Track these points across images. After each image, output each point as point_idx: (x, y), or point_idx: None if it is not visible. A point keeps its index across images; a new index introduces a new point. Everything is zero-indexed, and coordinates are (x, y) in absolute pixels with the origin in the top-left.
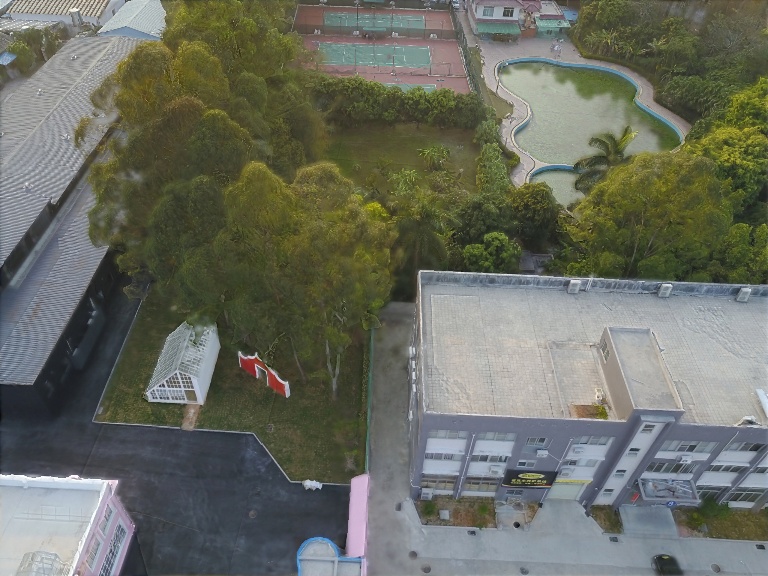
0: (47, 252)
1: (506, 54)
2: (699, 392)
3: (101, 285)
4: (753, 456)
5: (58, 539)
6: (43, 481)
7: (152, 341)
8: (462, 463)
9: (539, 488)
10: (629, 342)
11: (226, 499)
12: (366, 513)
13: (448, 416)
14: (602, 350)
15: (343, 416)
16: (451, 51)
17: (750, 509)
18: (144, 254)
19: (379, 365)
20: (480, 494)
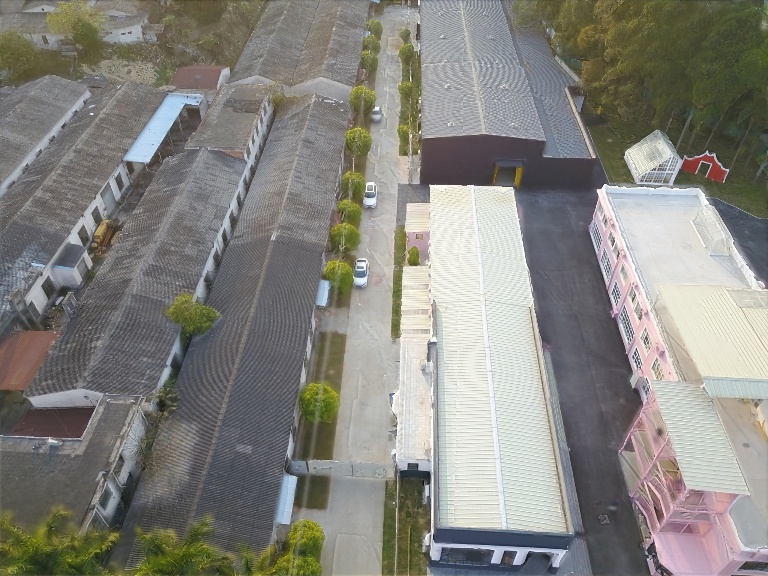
0: None
1: None
2: None
3: None
4: None
5: (692, 212)
6: (662, 189)
7: (611, 156)
8: None
9: None
10: None
11: None
12: None
13: None
14: None
15: (767, 191)
16: None
17: None
18: None
19: None
20: None
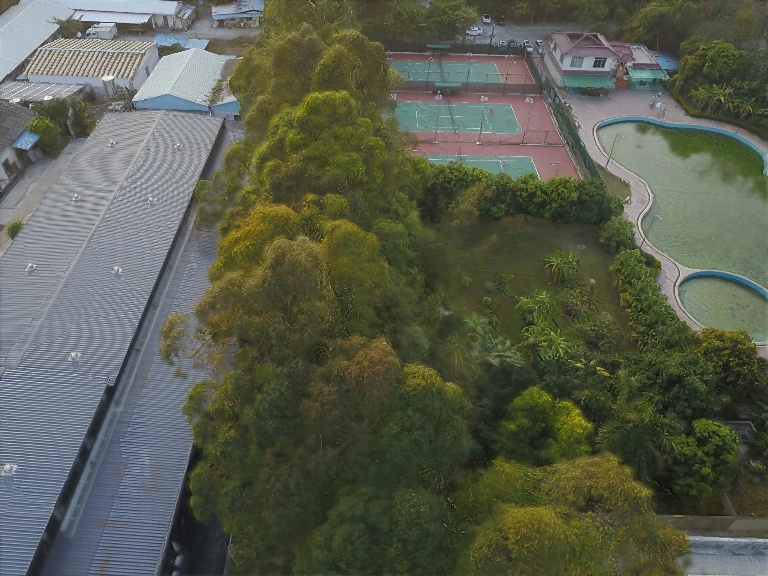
0: (107, 463)
1: (601, 113)
2: None
3: (182, 509)
4: None
5: None
6: None
7: None
8: None
9: None
10: None
11: None
12: None
13: None
14: None
15: None
16: (538, 110)
17: None
18: (277, 541)
19: None
20: None
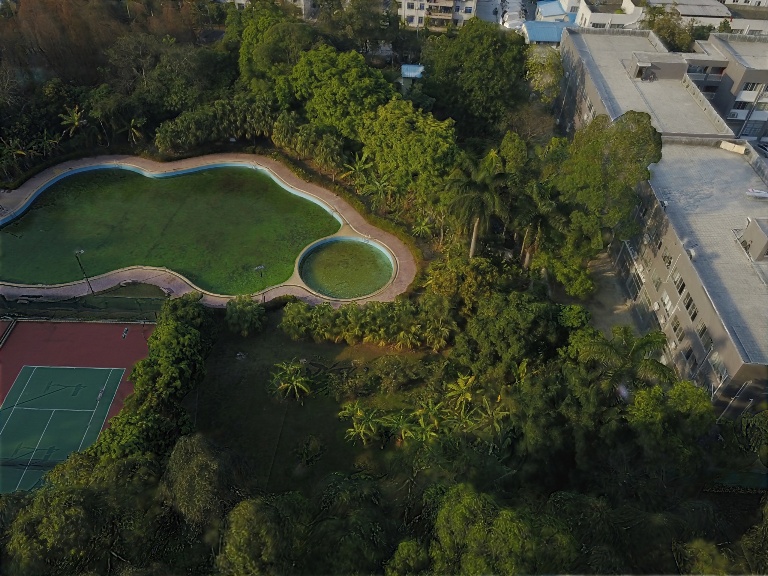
0: None
1: None
2: None
3: None
4: None
5: None
6: None
7: None
8: None
9: None
10: None
11: None
12: None
13: None
14: (767, 255)
15: None
16: None
17: None
18: None
19: None
20: None
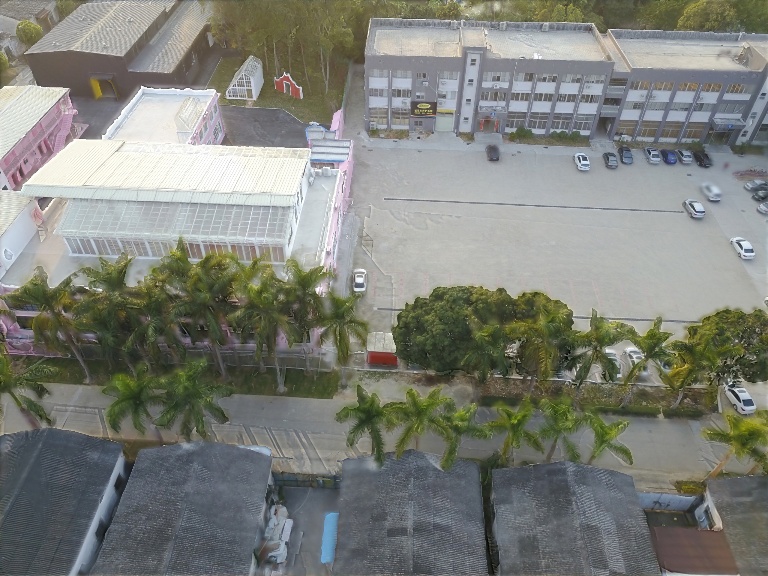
0: (166, 33)
1: None
2: (505, 56)
3: (196, 51)
4: (531, 85)
5: None
6: (186, 90)
7: (226, 80)
8: (388, 98)
9: (430, 117)
10: (470, 32)
11: (270, 127)
12: (340, 118)
13: (376, 56)
14: (459, 41)
15: None
16: None
17: (544, 134)
18: (227, 5)
19: (353, 91)
20: (401, 128)
